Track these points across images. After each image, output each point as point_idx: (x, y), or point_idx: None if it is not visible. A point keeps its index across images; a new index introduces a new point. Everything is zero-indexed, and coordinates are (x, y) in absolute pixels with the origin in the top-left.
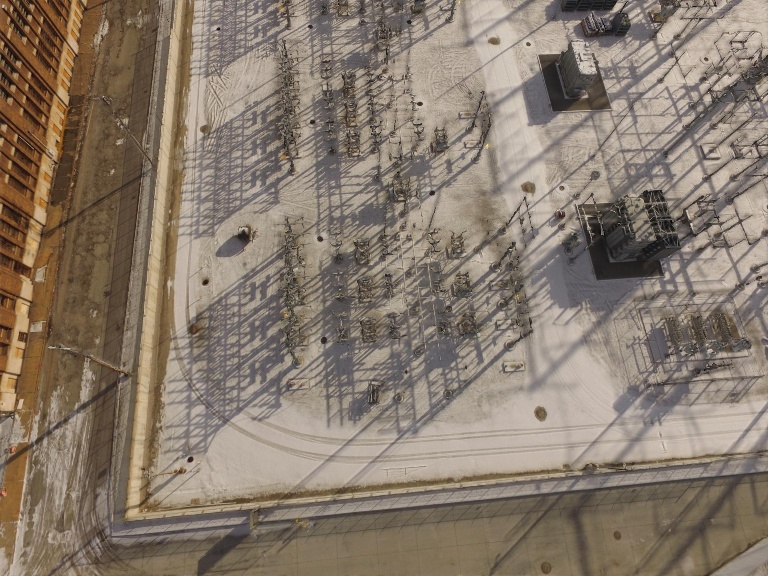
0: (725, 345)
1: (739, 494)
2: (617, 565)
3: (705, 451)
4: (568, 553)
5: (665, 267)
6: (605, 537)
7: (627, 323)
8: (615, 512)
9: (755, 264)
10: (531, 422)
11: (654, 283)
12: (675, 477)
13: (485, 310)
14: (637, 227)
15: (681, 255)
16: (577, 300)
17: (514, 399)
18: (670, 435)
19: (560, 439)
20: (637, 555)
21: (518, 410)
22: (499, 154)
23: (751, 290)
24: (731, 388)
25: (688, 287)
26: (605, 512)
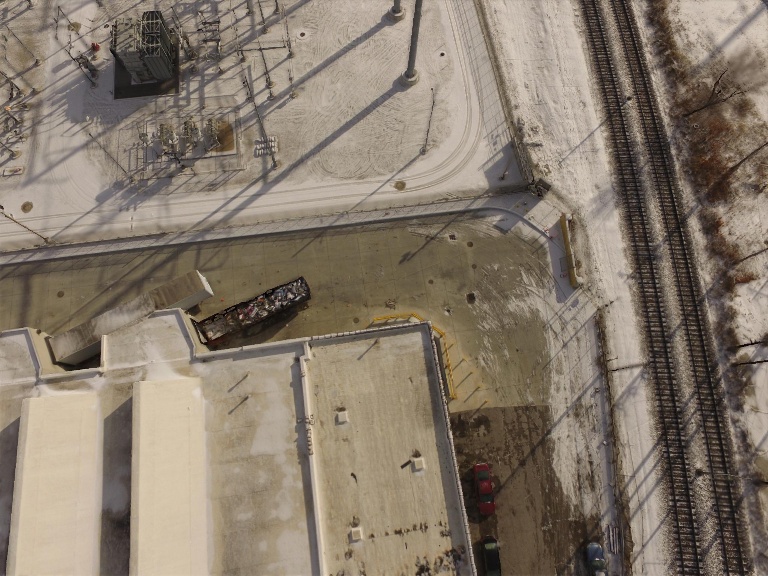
0: (217, 146)
1: (183, 258)
2: (53, 316)
3: (170, 229)
4: (11, 309)
5: (184, 87)
6: (49, 296)
7: (131, 132)
8: (64, 277)
9: (271, 81)
10: (16, 214)
11: (168, 100)
12: (126, 247)
13: (1, 128)
14: (120, 41)
15: (203, 76)
16: (90, 116)
17: (6, 197)
18: (141, 218)
19: (37, 225)
20: (74, 308)
21: (7, 205)
22: (56, 1)
23: (260, 102)
24: (212, 180)
25: (200, 102)
26: (55, 277)
